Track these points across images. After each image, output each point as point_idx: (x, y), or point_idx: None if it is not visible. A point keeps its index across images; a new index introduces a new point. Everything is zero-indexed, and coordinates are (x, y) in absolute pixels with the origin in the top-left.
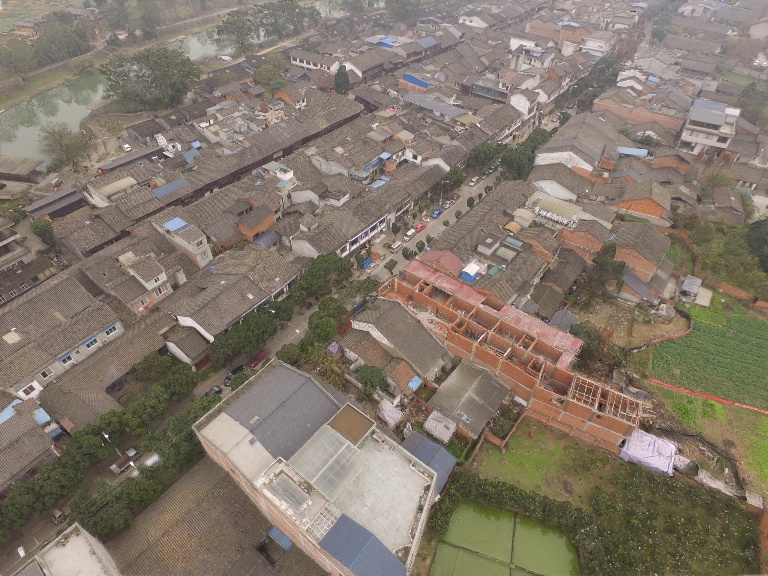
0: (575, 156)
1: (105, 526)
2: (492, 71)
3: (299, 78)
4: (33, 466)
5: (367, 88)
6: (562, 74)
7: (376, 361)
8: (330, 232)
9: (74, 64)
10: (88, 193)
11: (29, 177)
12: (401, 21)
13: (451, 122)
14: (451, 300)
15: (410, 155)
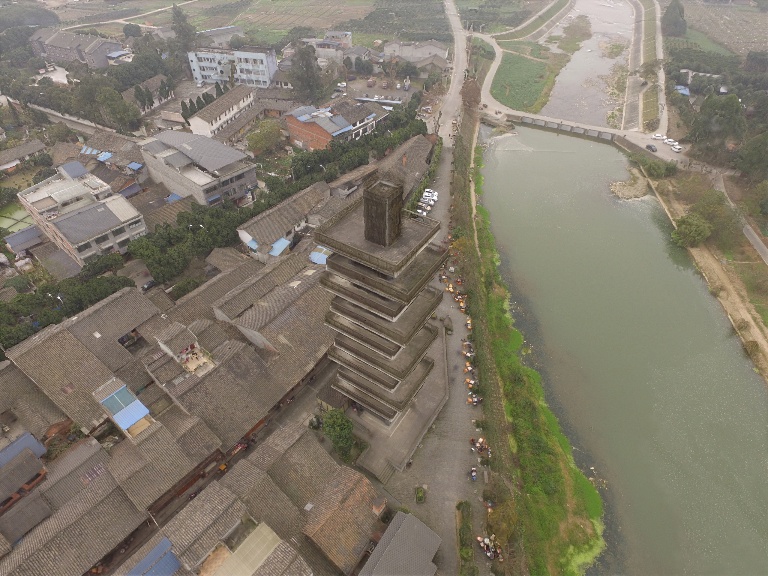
0: None
1: None
2: None
3: None
4: None
5: None
6: None
7: None
8: None
9: None
10: None
11: None
12: None
13: None
14: None
15: None
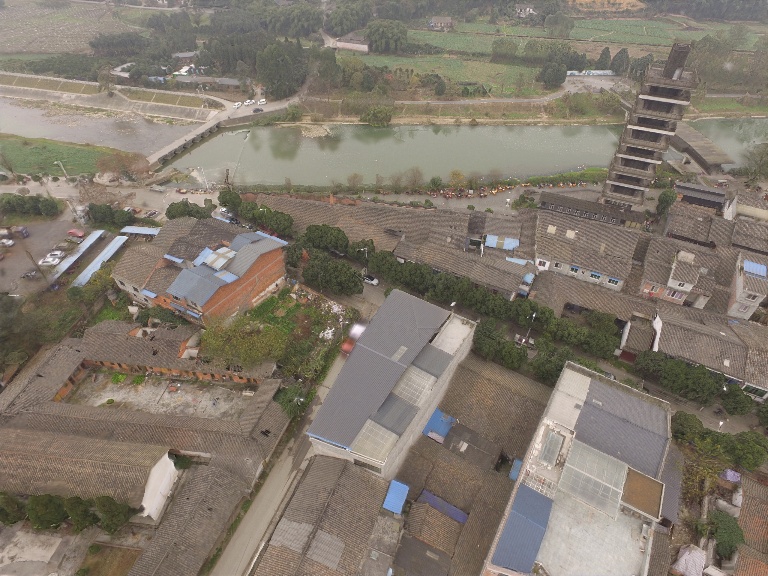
0: None
1: (480, 344)
2: None
3: None
4: (499, 290)
5: None
6: None
7: (751, 532)
8: None
9: None
10: (730, 202)
11: (710, 167)
12: None
13: None
14: None
15: None
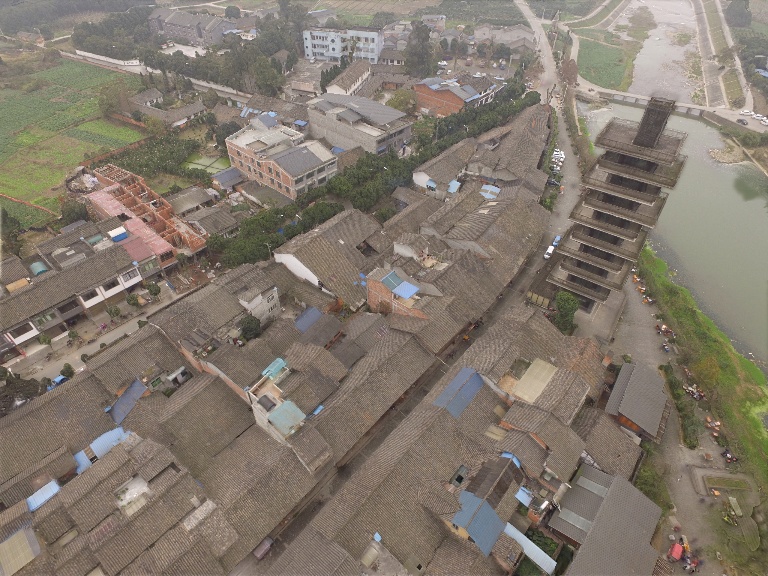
0: None
1: None
2: None
3: None
4: None
5: None
6: None
7: None
8: None
9: None
10: (597, 409)
11: None
12: None
13: None
14: (152, 227)
15: None
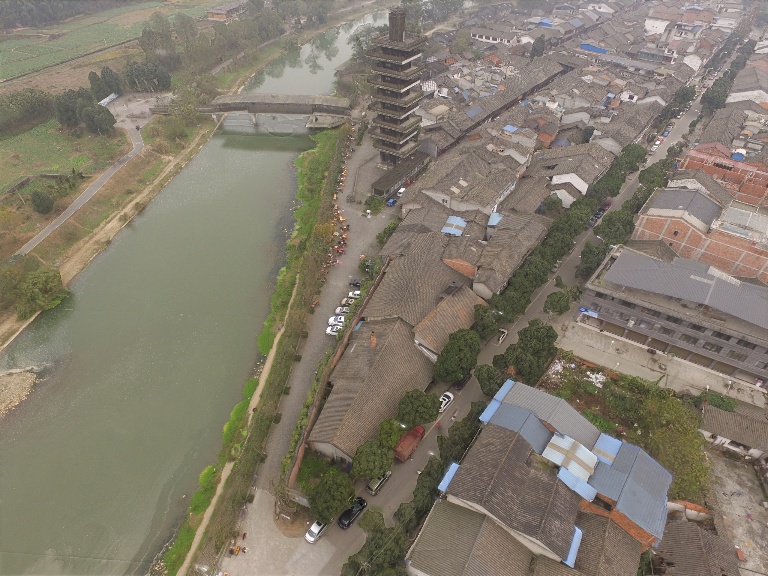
0: (764, 93)
1: None
2: (653, 41)
3: (486, 49)
4: None
5: (558, 53)
6: (713, 43)
7: None
8: (621, 134)
9: (286, 41)
10: None
11: (344, 111)
12: (539, 8)
13: (646, 75)
14: None
15: (626, 96)
